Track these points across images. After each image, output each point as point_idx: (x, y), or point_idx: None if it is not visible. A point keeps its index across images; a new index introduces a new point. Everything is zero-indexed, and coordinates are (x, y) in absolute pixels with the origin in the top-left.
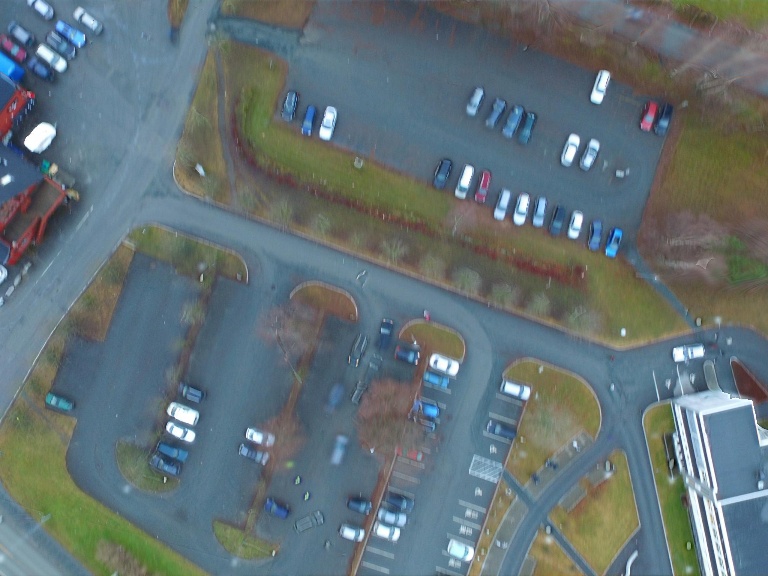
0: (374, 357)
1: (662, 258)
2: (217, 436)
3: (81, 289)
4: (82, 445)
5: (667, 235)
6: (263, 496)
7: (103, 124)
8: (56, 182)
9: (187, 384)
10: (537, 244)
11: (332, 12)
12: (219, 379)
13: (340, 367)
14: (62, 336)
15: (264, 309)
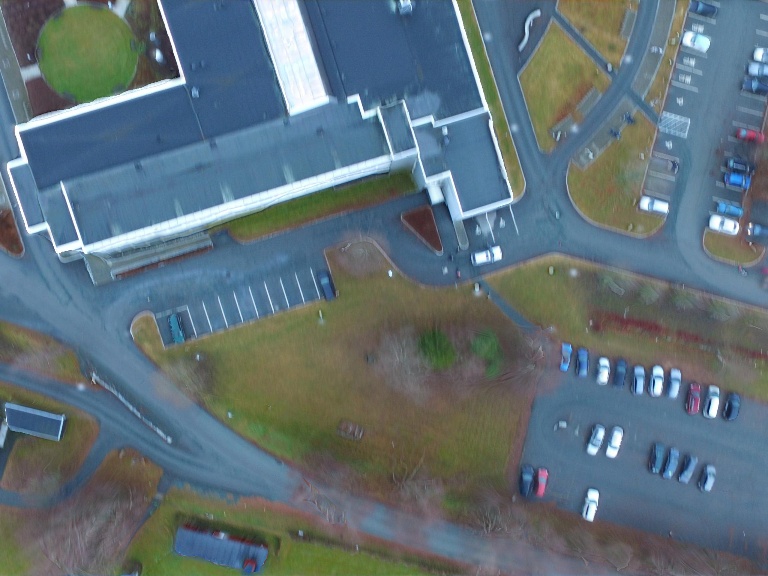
0: None
1: None
2: None
3: None
4: None
5: None
6: None
7: None
8: None
9: None
10: (636, 349)
11: None
12: None
13: None
14: None
15: None
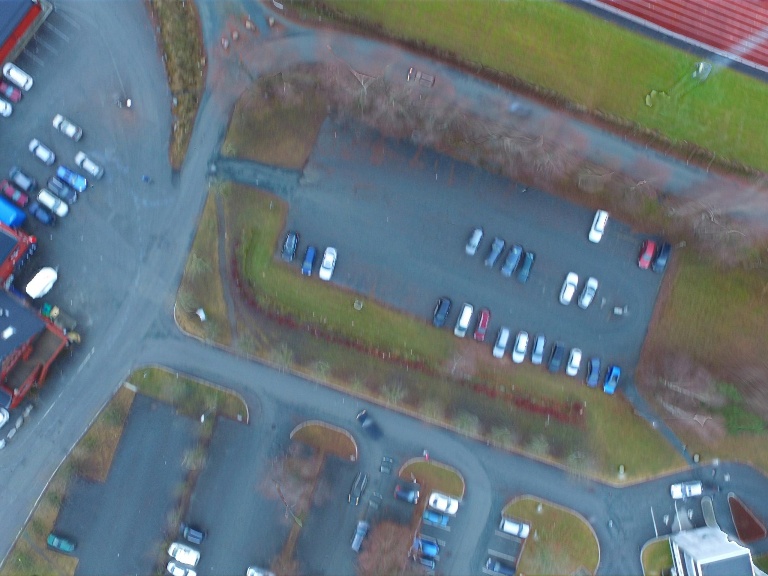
0: (374, 495)
1: (660, 399)
2: (218, 575)
3: (82, 430)
4: None
5: (665, 376)
6: None
7: (104, 266)
8: (57, 326)
9: (188, 525)
10: (536, 380)
11: (332, 153)
12: (220, 518)
13: (340, 506)
14: (64, 477)
15: (264, 449)
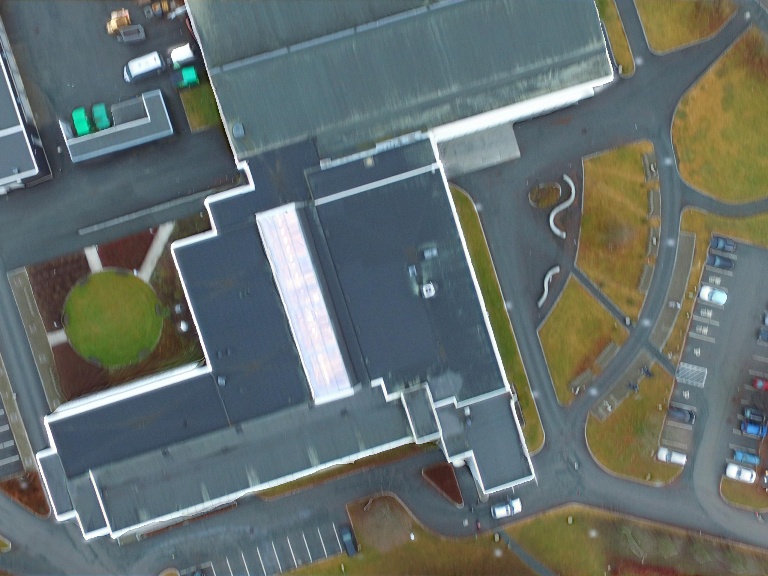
0: None
1: None
2: None
3: None
4: None
5: None
6: None
7: None
8: None
9: None
10: None
11: None
12: None
13: None
14: None
15: None
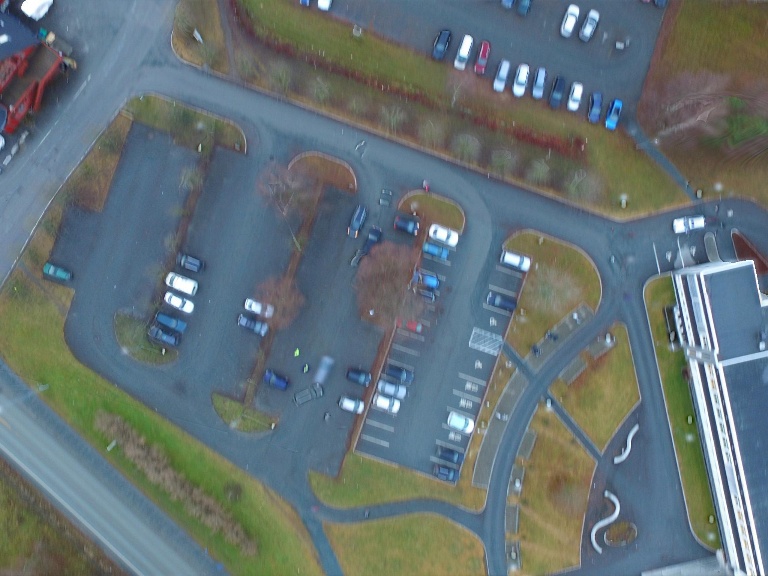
0: (373, 228)
1: (662, 126)
2: (216, 308)
3: (79, 159)
4: (80, 316)
5: (667, 103)
6: (262, 368)
7: None
8: (53, 49)
9: (185, 253)
10: (537, 117)
11: None
12: (218, 250)
13: (339, 238)
14: (60, 206)
15: (263, 180)
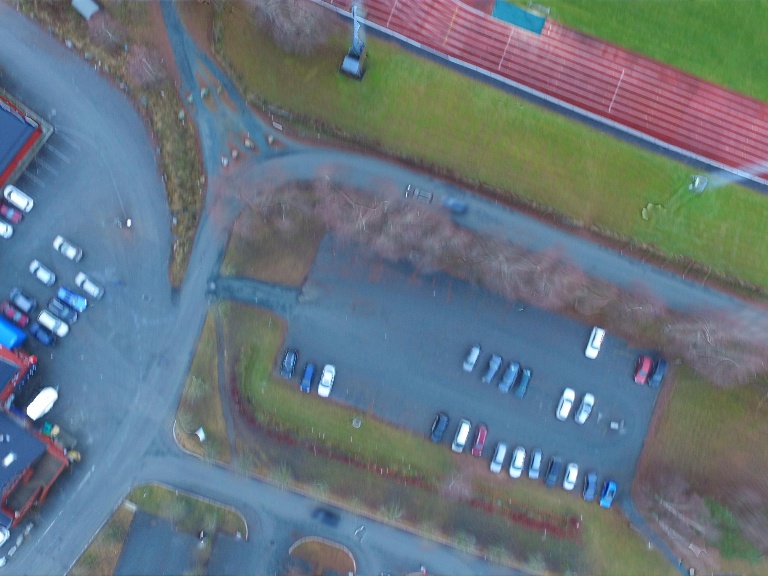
0: None
1: (656, 517)
2: None
3: (83, 547)
4: None
5: (661, 495)
6: None
7: (104, 385)
8: (58, 446)
9: None
10: (533, 494)
11: (330, 271)
12: None
13: None
14: None
15: (263, 565)
